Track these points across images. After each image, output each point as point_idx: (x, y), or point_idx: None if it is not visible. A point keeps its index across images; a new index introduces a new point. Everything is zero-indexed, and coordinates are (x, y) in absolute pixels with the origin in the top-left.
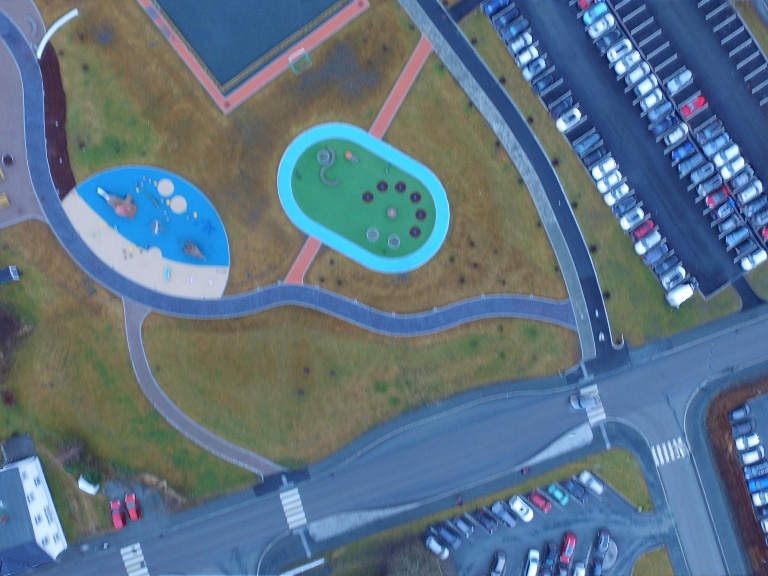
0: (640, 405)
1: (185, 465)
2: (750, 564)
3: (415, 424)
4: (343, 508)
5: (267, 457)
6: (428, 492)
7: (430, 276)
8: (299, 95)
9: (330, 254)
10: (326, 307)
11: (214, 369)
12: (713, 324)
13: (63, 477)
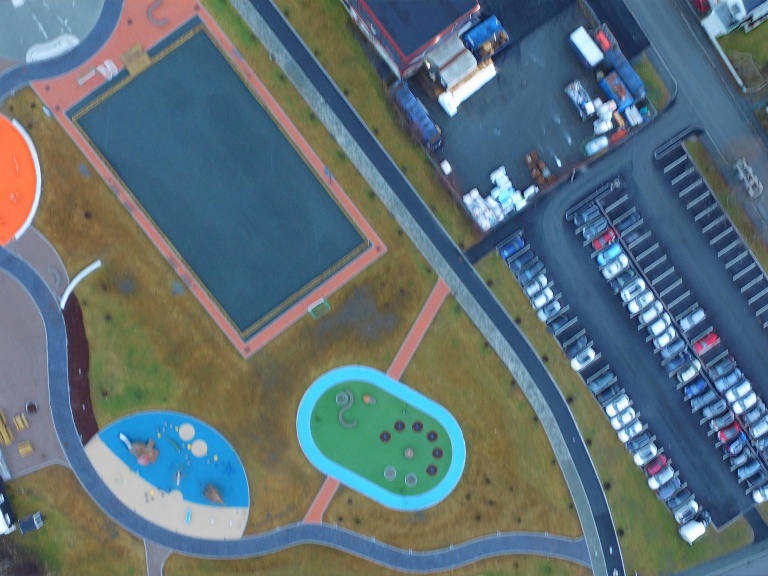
0: None
1: None
2: None
3: None
4: None
5: None
6: None
7: (446, 514)
8: (318, 339)
9: (348, 494)
10: (344, 545)
11: None
12: (725, 558)
13: None
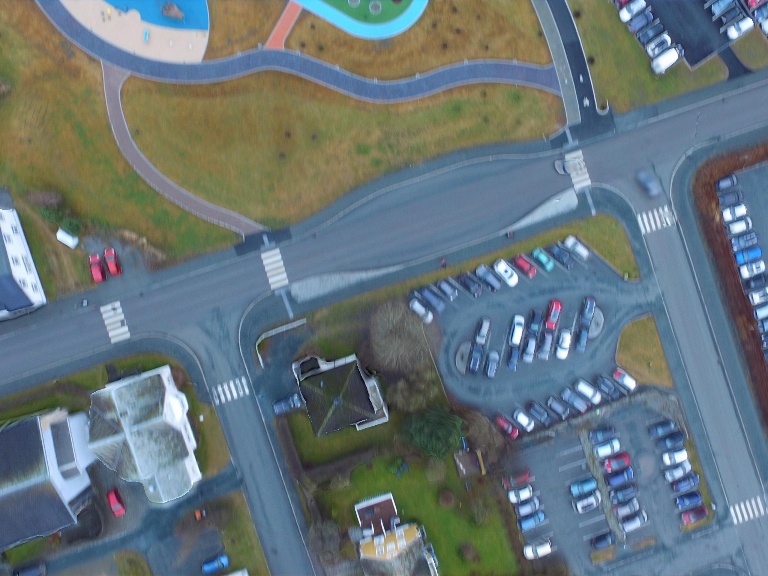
0: (625, 172)
1: (165, 225)
2: (738, 334)
3: (398, 185)
4: (325, 269)
5: (248, 216)
6: (411, 255)
7: (412, 42)
8: None
9: (311, 19)
10: (307, 73)
11: (194, 133)
12: (699, 92)
13: (41, 232)
